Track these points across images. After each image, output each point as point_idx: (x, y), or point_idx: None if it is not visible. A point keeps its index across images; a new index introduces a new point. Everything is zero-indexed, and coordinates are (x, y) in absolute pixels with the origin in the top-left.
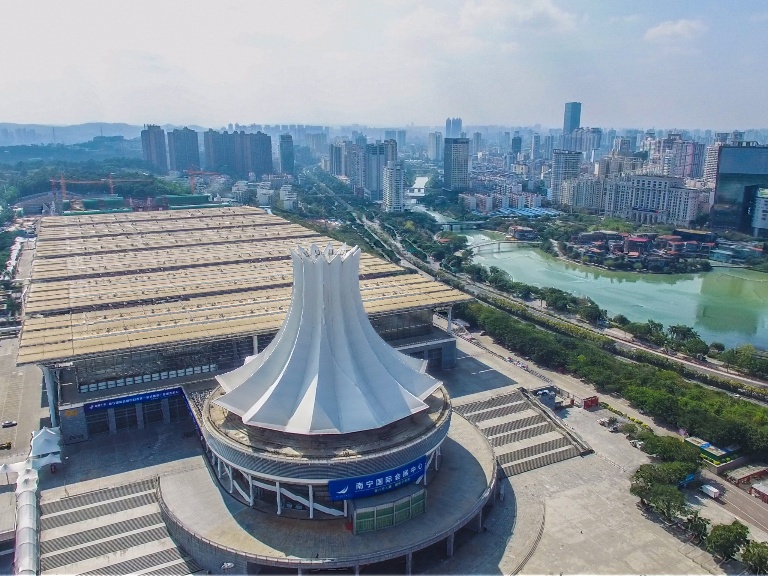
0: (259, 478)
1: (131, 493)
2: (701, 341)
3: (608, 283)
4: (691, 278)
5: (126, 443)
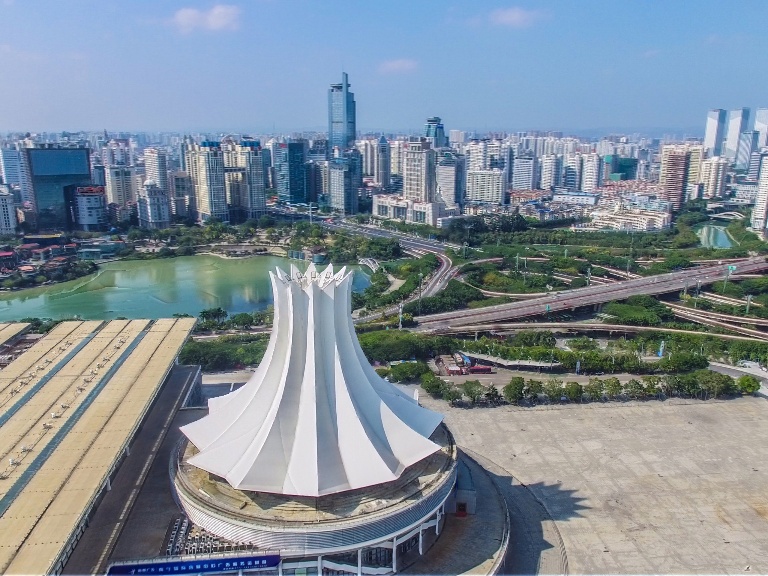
0: None
1: None
2: (247, 314)
3: (8, 306)
4: (89, 279)
5: None
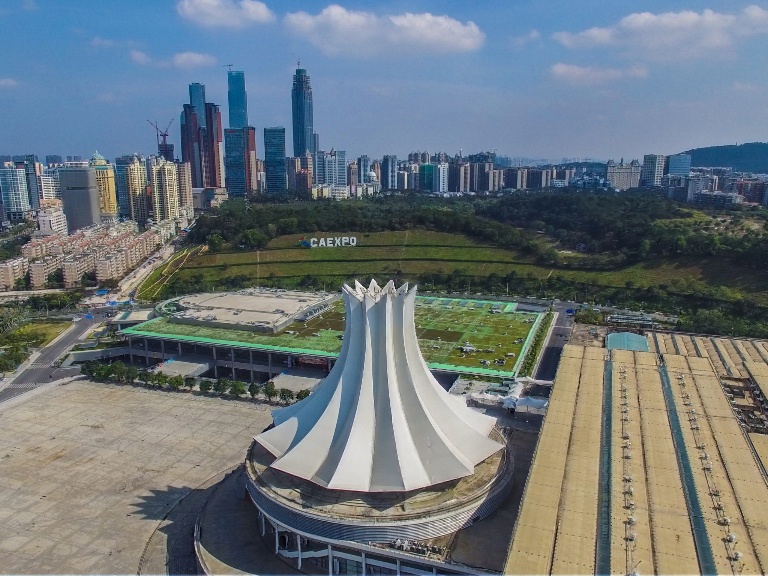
0: None
1: None
2: None
3: None
4: None
5: None
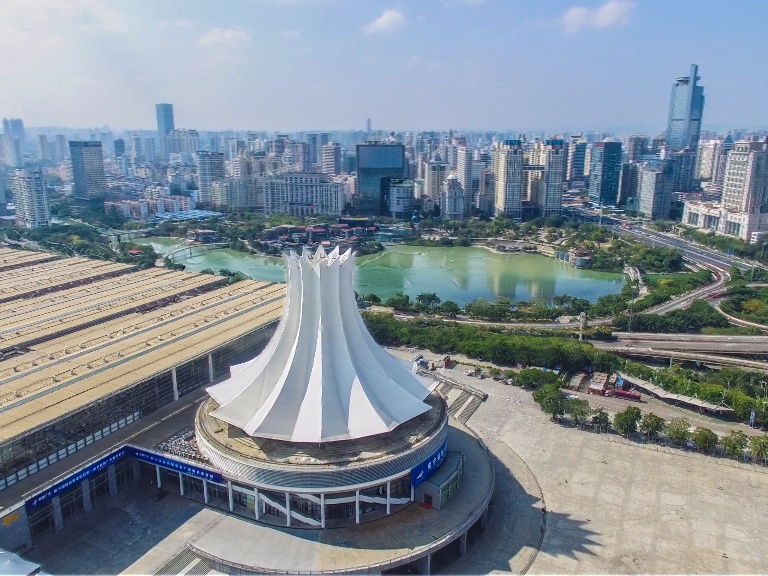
0: (345, 492)
1: (176, 573)
2: (452, 302)
3: None
4: (373, 258)
5: (93, 531)
